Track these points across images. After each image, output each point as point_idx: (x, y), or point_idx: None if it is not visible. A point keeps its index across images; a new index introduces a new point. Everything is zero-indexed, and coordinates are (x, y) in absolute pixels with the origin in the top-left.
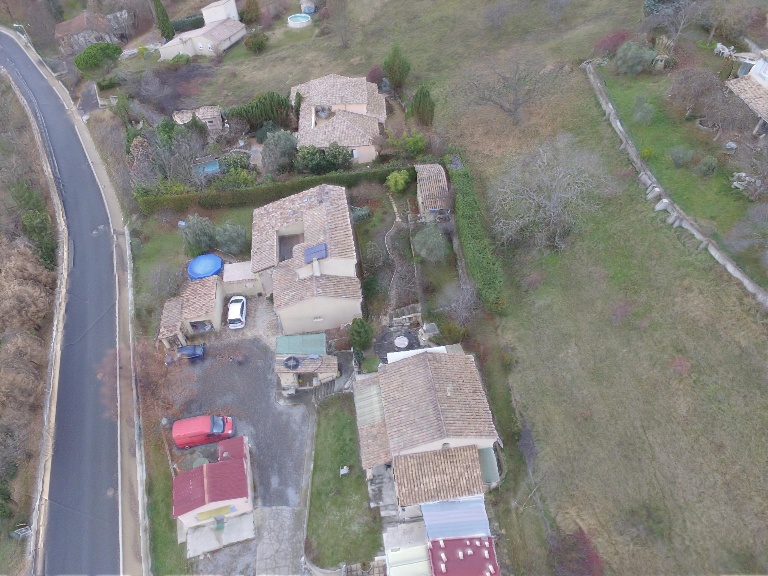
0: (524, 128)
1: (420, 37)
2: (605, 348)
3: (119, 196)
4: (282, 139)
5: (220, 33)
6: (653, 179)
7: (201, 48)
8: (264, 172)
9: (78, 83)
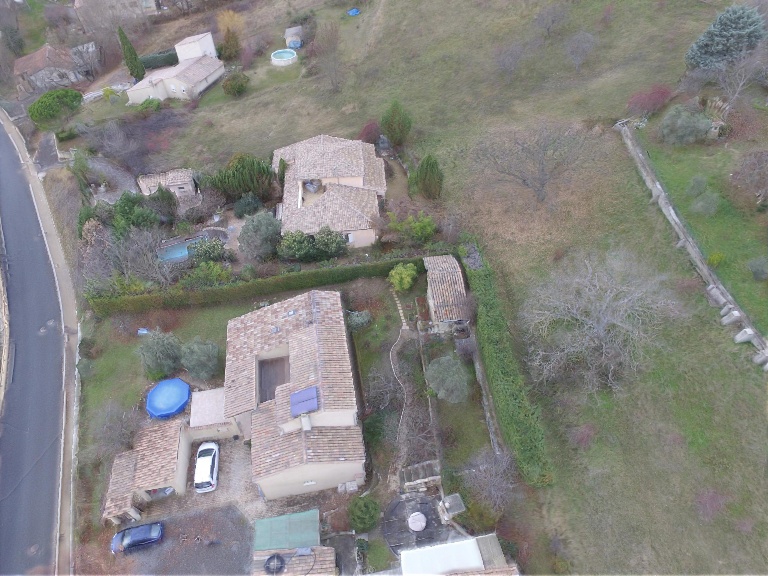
0: (552, 207)
1: (420, 81)
2: (693, 556)
3: (74, 280)
4: (263, 224)
5: (195, 73)
6: (729, 297)
7: (174, 90)
8: (243, 258)
9: (35, 131)
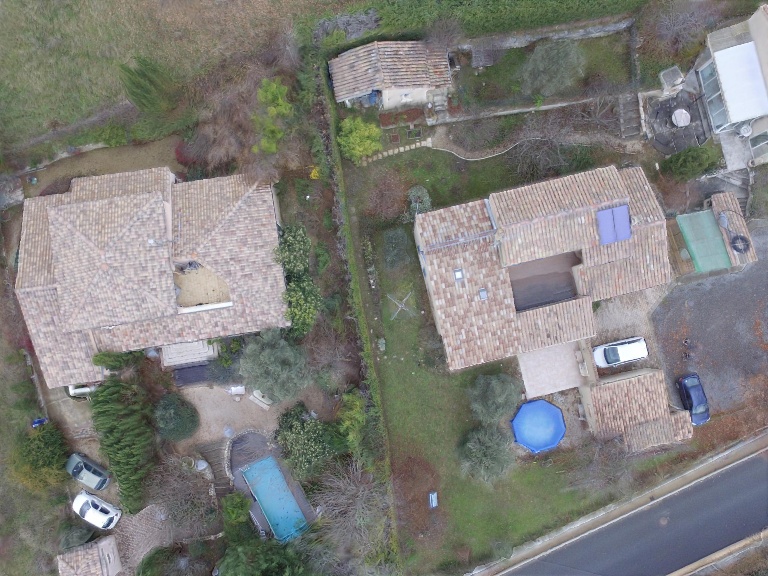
0: None
1: None
2: None
3: None
4: (280, 354)
5: None
6: None
7: None
8: None
9: None
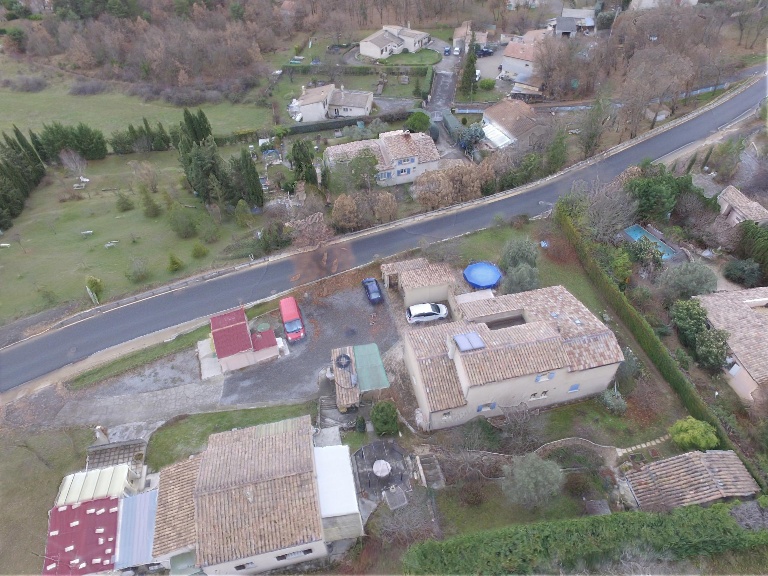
0: None
1: None
2: None
3: None
4: (693, 275)
5: None
6: None
7: None
8: None
9: None
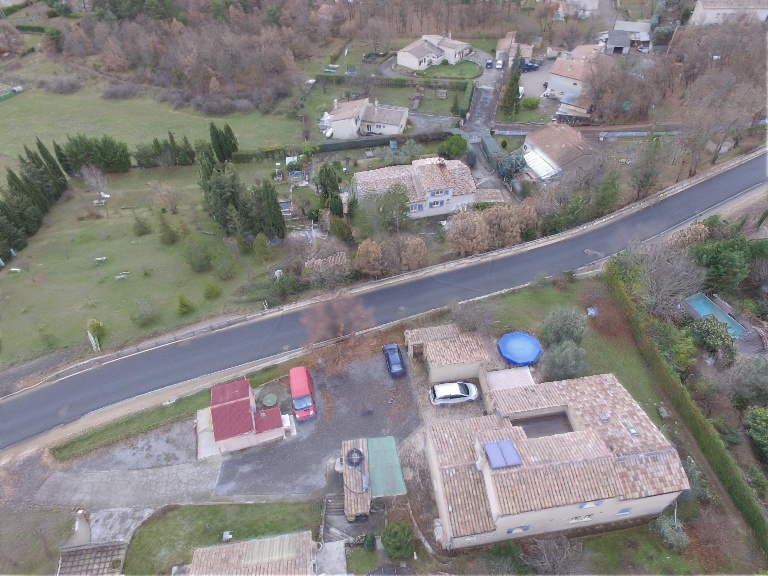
0: None
1: None
2: None
3: None
4: None
5: None
6: None
7: None
8: None
9: None
